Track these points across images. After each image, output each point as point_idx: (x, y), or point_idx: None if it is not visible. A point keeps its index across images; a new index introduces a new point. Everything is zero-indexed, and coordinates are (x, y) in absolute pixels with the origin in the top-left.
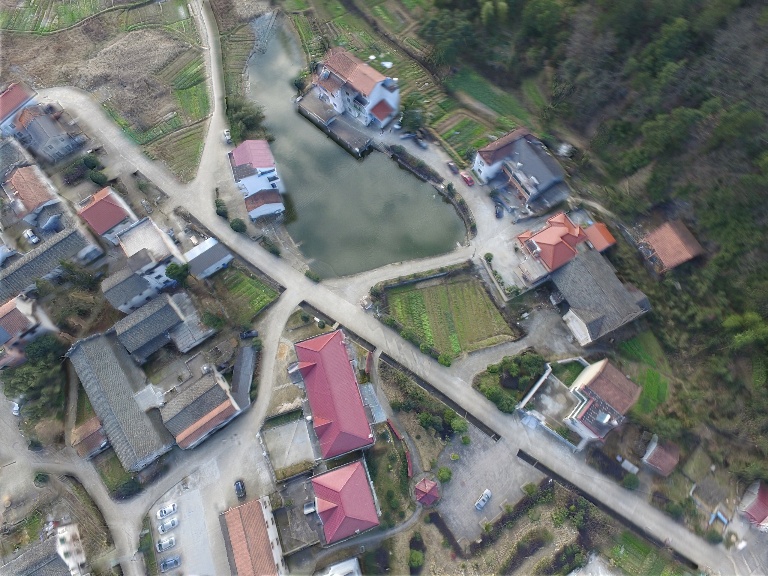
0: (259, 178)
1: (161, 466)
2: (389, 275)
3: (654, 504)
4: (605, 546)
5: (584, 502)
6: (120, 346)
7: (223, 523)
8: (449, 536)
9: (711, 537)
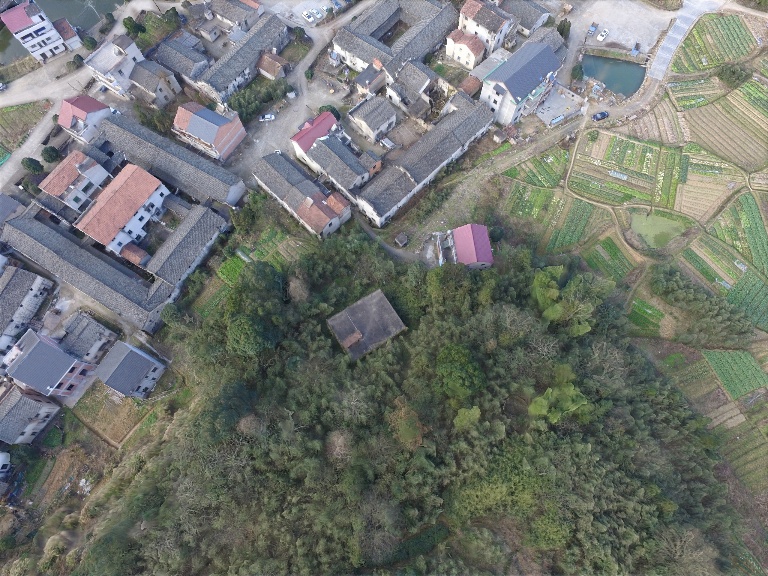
0: None
1: None
2: None
3: None
4: None
5: None
6: None
7: None
8: None
9: None
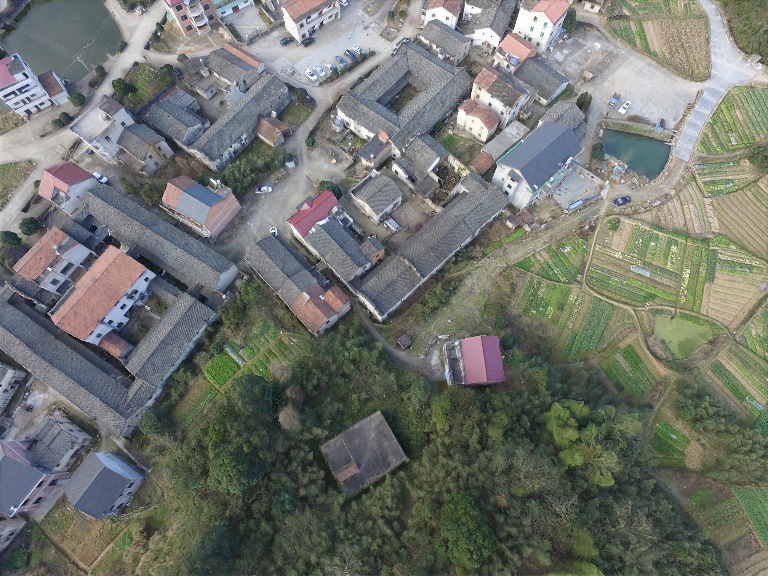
0: (24, 65)
1: None
2: (115, 5)
3: None
4: None
5: None
6: None
7: (299, 19)
8: None
9: None
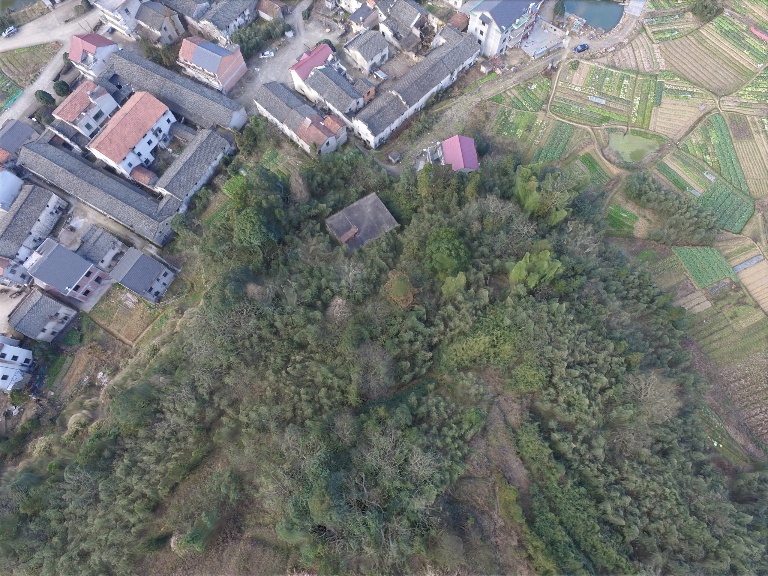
0: None
1: None
2: None
3: None
4: None
5: None
6: None
7: None
8: None
9: None
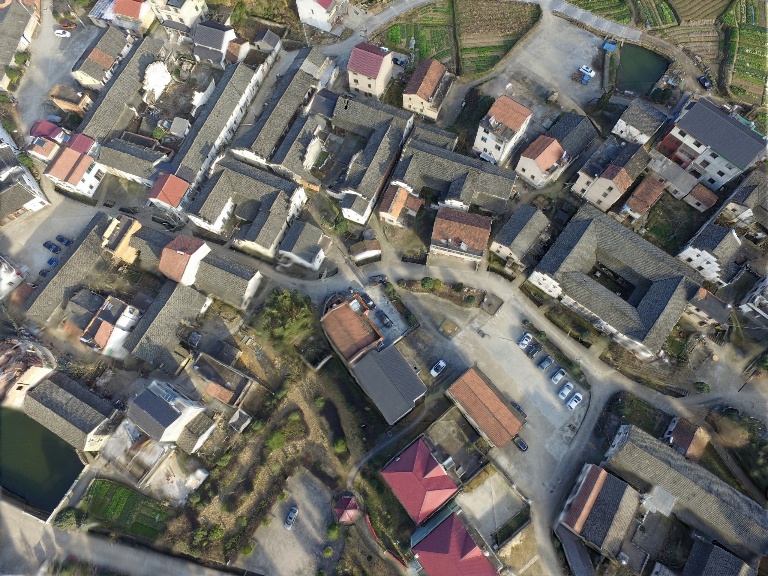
0: None
1: (605, 436)
2: None
3: (126, 575)
4: (173, 515)
5: (194, 553)
6: (732, 547)
7: (520, 417)
8: (316, 473)
9: (73, 562)
